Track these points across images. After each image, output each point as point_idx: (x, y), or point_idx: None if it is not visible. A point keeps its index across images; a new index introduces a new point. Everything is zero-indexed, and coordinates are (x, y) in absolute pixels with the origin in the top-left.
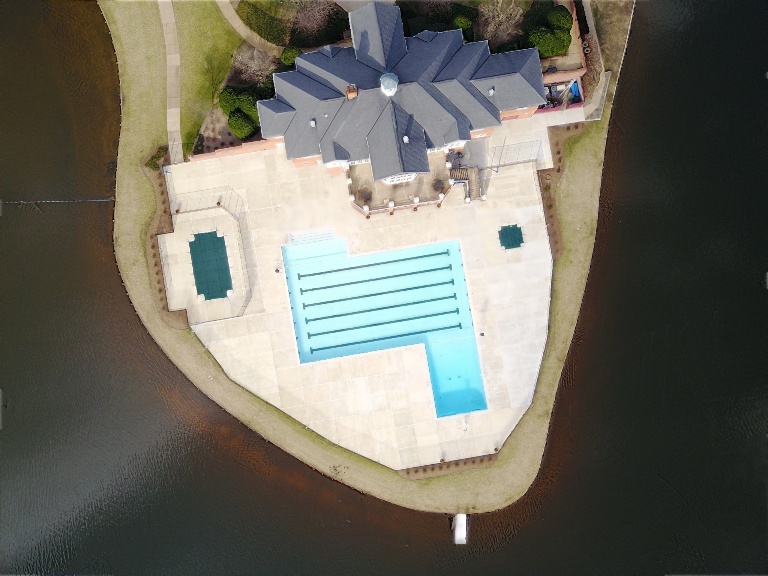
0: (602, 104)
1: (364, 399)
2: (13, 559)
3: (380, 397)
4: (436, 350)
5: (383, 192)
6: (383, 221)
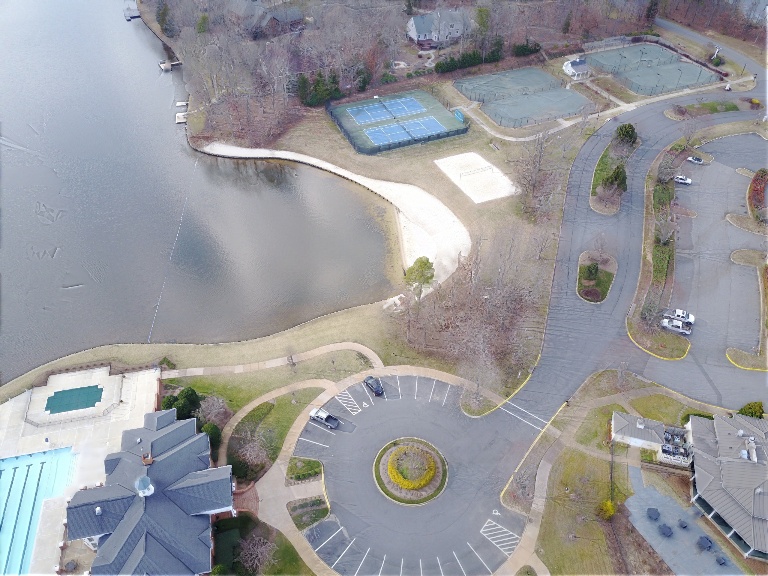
0: None
1: None
2: None
3: None
4: None
5: None
6: None
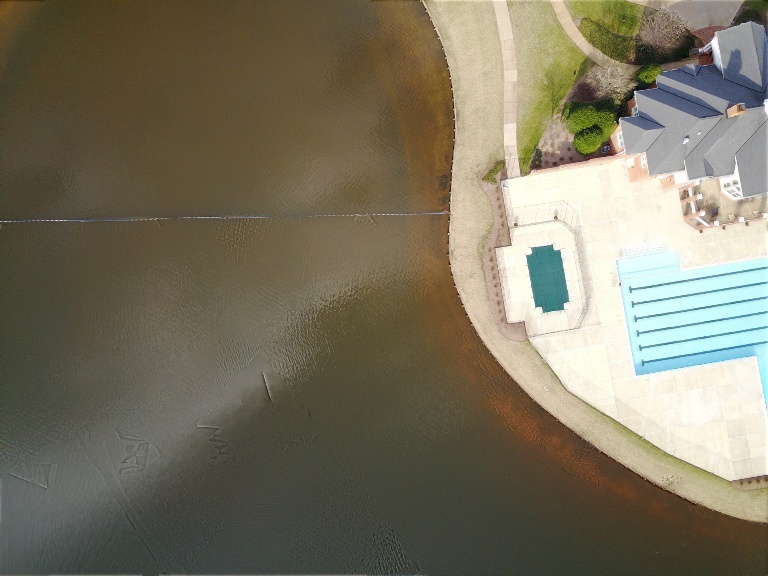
0: None
1: (698, 411)
2: (359, 568)
3: (713, 409)
4: (763, 362)
5: (728, 207)
6: (714, 235)
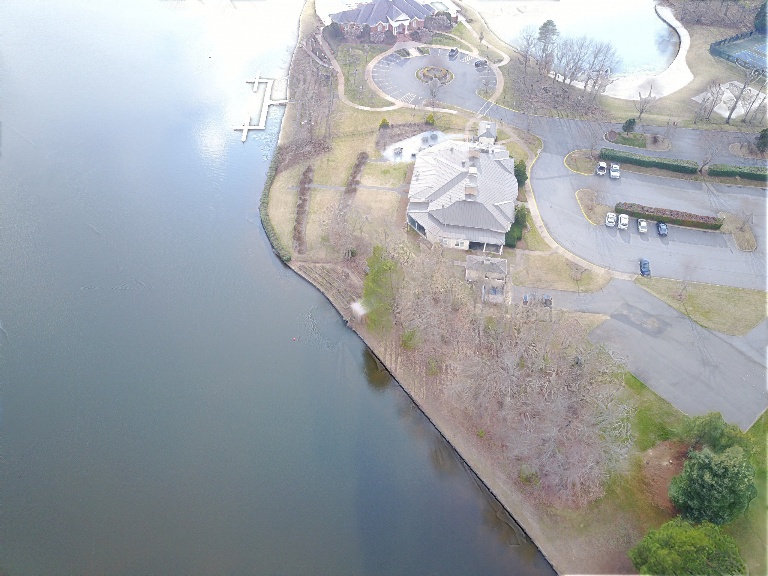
0: None
1: None
2: None
3: None
4: None
5: None
6: None
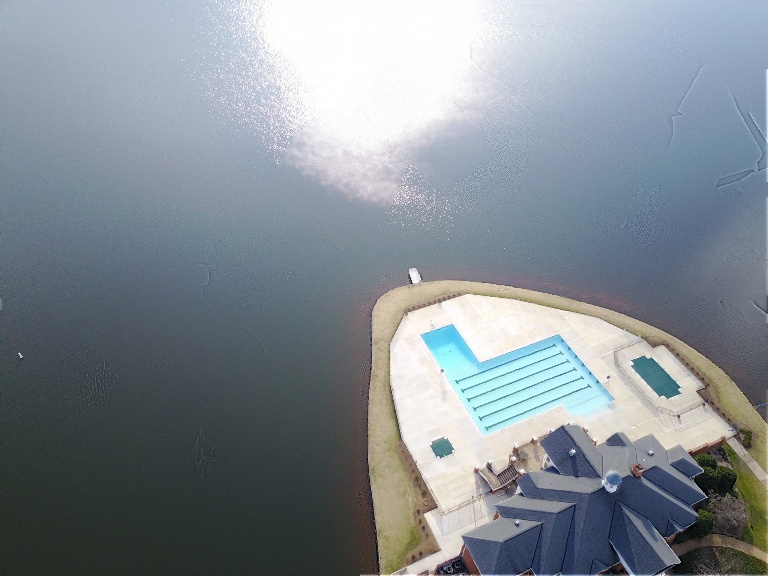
0: None
1: (506, 324)
2: (659, 221)
3: (496, 327)
4: None
5: None
6: None
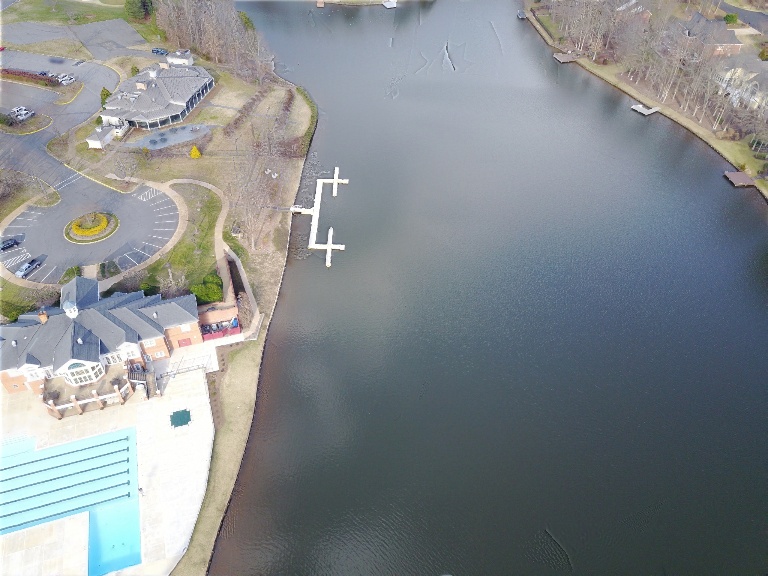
0: (257, 330)
1: (15, 573)
2: None
3: (33, 568)
4: (102, 519)
5: (70, 393)
6: (73, 421)
